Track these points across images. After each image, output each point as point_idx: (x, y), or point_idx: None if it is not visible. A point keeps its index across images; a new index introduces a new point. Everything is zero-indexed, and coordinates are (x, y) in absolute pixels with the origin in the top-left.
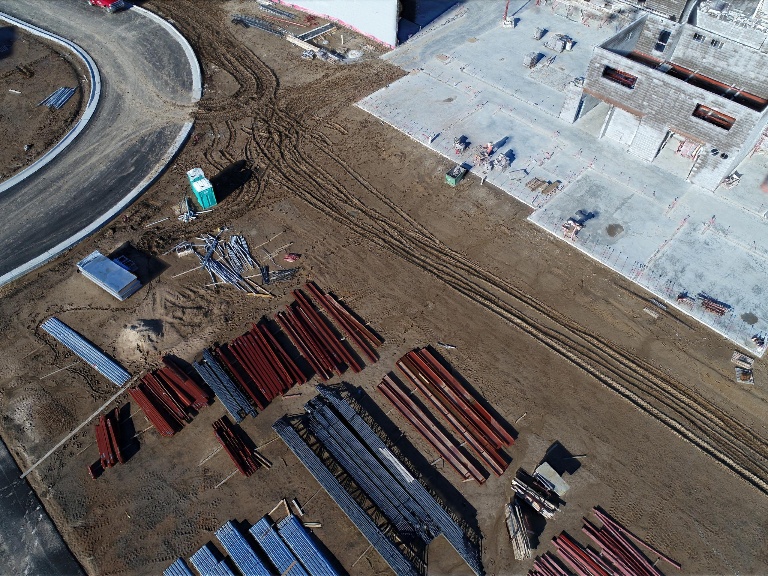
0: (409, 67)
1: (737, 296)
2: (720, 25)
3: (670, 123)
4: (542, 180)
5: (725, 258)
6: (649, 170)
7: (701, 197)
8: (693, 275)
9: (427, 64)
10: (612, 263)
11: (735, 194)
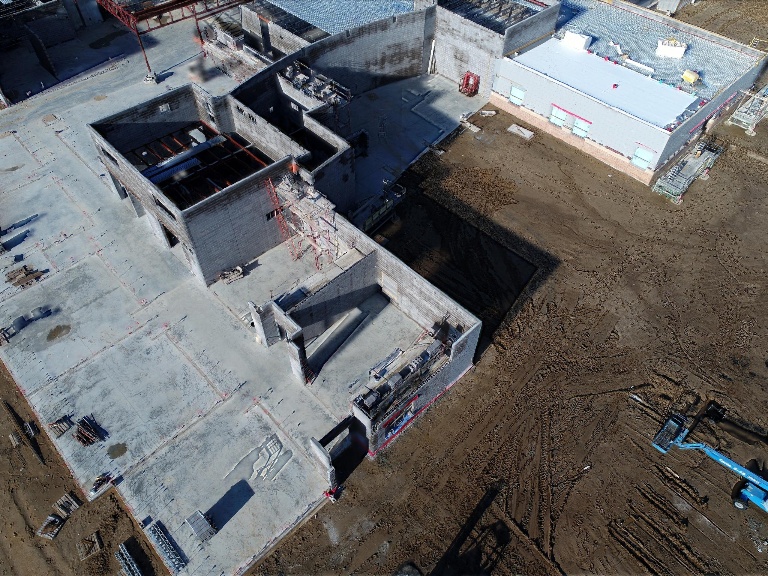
0: (3, 129)
1: (126, 421)
2: (296, 93)
3: (153, 211)
4: (30, 268)
5: (153, 371)
6: (160, 258)
7: (190, 292)
8: (98, 392)
9: (26, 126)
10: (19, 375)
11: (232, 289)
